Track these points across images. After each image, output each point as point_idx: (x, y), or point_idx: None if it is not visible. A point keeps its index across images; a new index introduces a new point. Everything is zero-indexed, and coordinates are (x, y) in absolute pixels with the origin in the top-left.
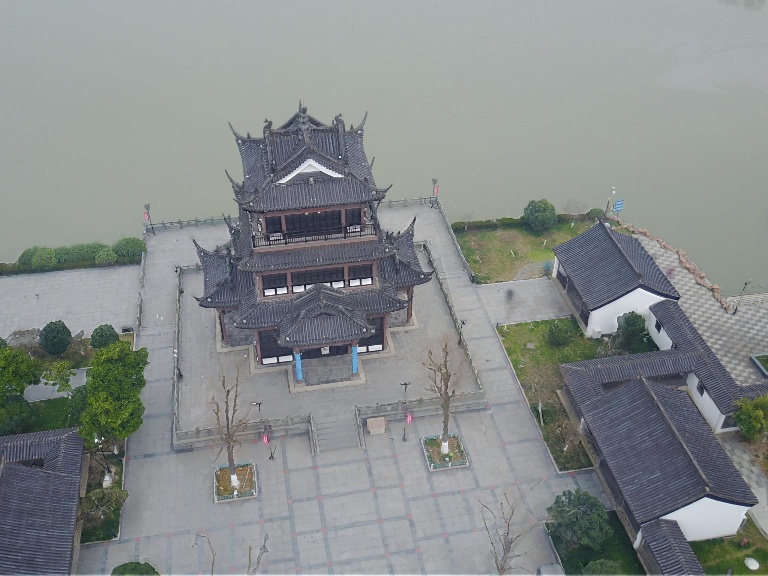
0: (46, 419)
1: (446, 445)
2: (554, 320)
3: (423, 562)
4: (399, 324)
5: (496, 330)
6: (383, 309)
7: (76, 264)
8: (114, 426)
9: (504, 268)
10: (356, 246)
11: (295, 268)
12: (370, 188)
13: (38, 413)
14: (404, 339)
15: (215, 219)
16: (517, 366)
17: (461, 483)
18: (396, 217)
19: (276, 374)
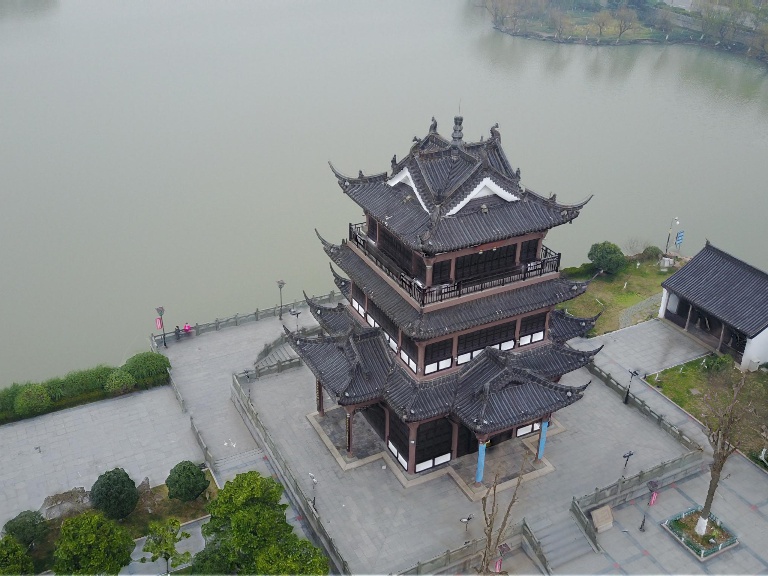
0: None
1: (706, 522)
2: (697, 360)
3: None
4: None
5: (646, 382)
6: (564, 368)
7: (79, 398)
8: None
9: (602, 318)
10: (532, 290)
11: (473, 327)
12: (558, 208)
13: None
14: (561, 410)
15: (239, 317)
16: (699, 416)
17: (747, 567)
18: None
19: (438, 482)
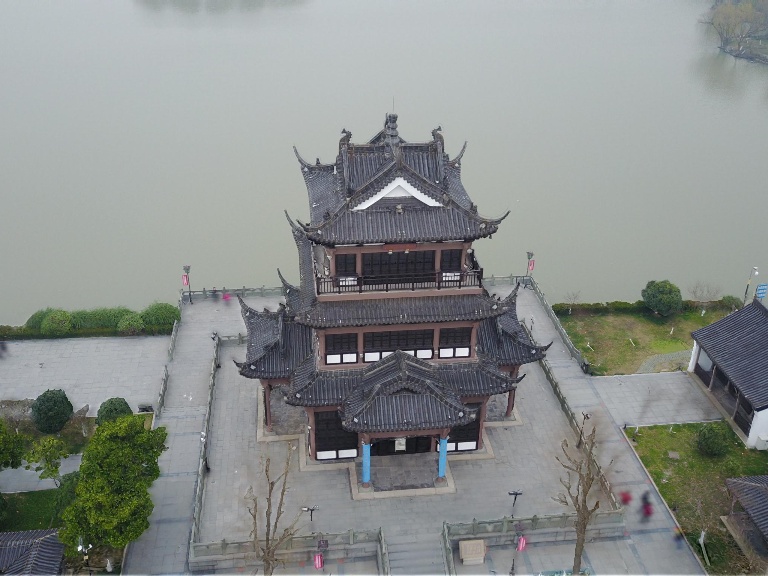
0: (23, 517)
1: None
2: (700, 424)
3: None
4: (496, 418)
5: (624, 433)
6: (483, 390)
7: (94, 330)
8: (106, 528)
9: (623, 358)
10: (452, 301)
11: (370, 325)
12: (477, 220)
13: (14, 509)
14: (504, 437)
15: (265, 289)
16: (659, 481)
17: None
18: None
19: (334, 473)
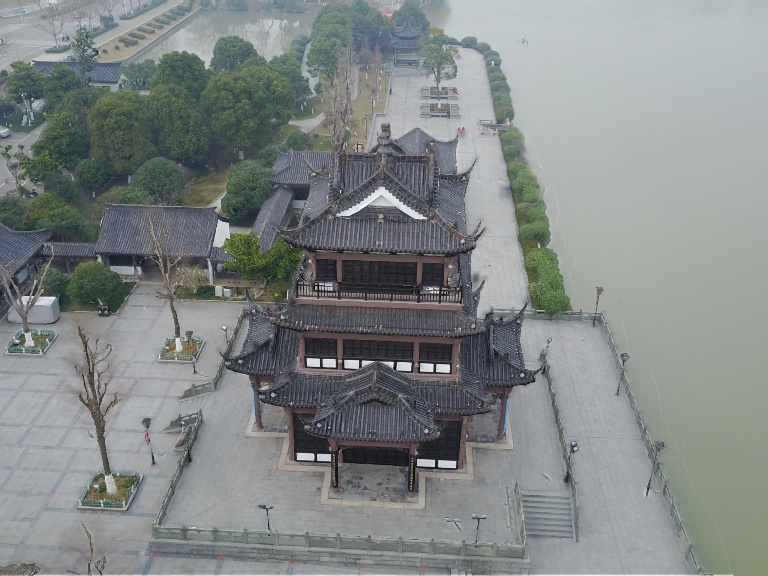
0: None
1: None
2: None
3: (3, 446)
4: None
5: None
6: None
7: (532, 278)
8: None
9: None
10: None
11: None
12: None
13: None
14: (306, 483)
15: None
16: None
17: (63, 495)
18: (655, 559)
19: None
